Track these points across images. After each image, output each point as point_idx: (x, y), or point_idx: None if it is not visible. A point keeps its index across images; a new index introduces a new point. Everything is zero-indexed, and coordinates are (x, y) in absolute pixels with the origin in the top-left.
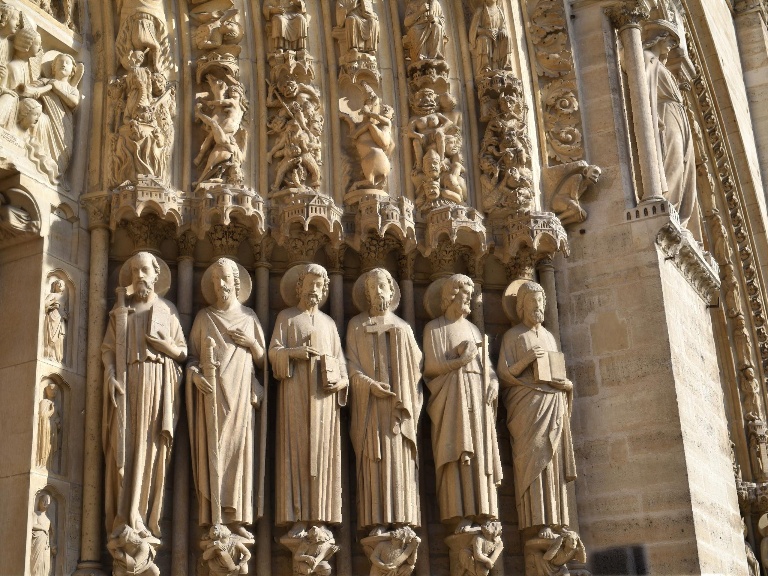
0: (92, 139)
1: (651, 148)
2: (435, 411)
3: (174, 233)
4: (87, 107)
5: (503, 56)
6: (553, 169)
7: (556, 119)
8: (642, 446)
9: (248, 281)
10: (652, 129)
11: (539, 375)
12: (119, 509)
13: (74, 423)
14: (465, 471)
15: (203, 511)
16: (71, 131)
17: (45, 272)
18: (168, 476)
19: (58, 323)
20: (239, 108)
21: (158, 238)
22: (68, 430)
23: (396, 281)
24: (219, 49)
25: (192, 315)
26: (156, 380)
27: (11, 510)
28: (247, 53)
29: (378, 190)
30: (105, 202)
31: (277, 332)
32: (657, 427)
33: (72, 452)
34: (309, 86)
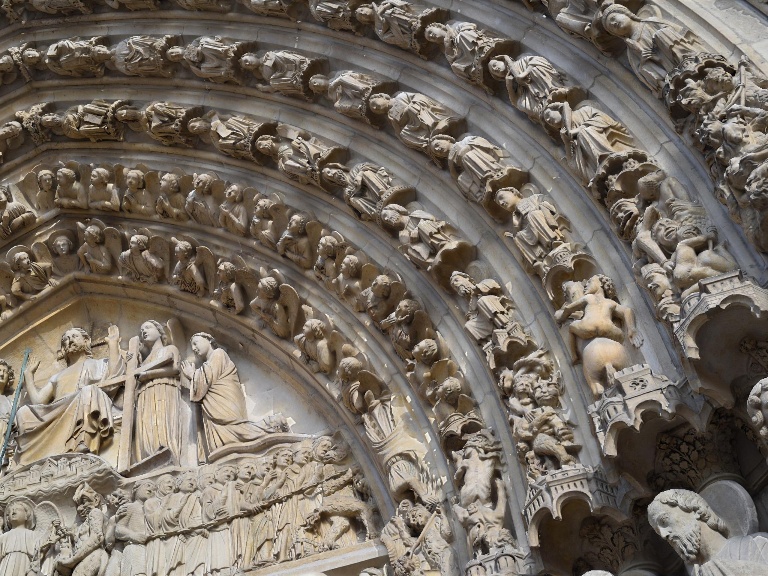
0: None
1: None
2: None
3: None
4: None
5: (671, 58)
6: None
7: None
8: None
9: None
10: None
11: None
12: None
13: None
14: None
15: None
16: None
17: None
18: None
19: None
20: (477, 462)
21: None
22: None
23: (767, 472)
24: None
25: None
26: None
27: None
28: (482, 391)
29: None
30: None
31: None
32: None
33: None
34: None
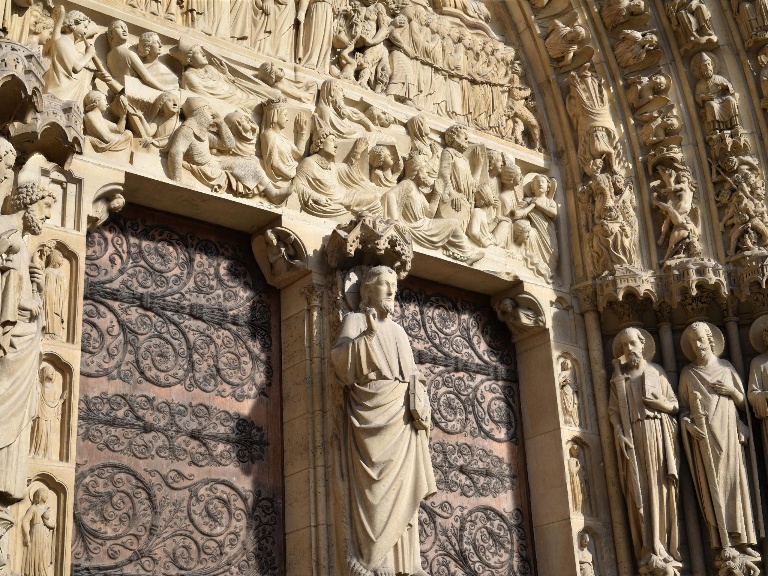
0: (572, 239)
1: None
2: None
3: (651, 305)
4: (564, 213)
5: None
6: None
7: None
8: None
9: (720, 337)
10: None
11: None
12: (644, 541)
13: (597, 474)
14: None
15: (713, 537)
16: (555, 237)
17: (555, 356)
18: (679, 509)
19: (571, 395)
20: (689, 190)
21: (639, 312)
22: (593, 480)
23: None
24: (663, 141)
25: (677, 372)
26: (657, 433)
27: (561, 549)
28: (688, 139)
29: None
30: (591, 290)
31: (753, 378)
32: None
33: (599, 497)
34: (747, 157)
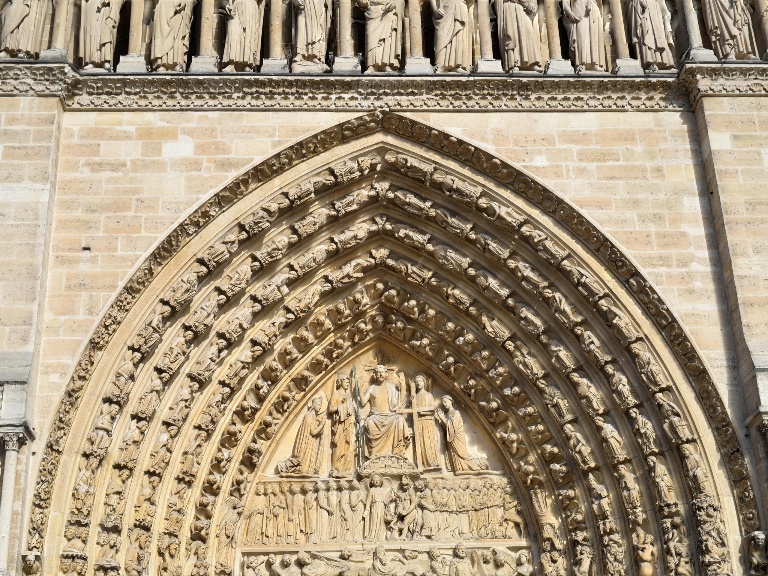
0: None
1: None
2: None
3: None
4: (539, 571)
5: None
6: (745, 538)
7: (744, 506)
8: None
9: None
10: None
11: None
12: None
13: None
14: None
15: None
16: None
17: None
18: None
19: None
20: (587, 558)
21: None
22: None
23: None
24: (578, 527)
25: None
26: None
27: None
28: (590, 524)
29: None
30: None
31: None
32: None
33: None
34: None
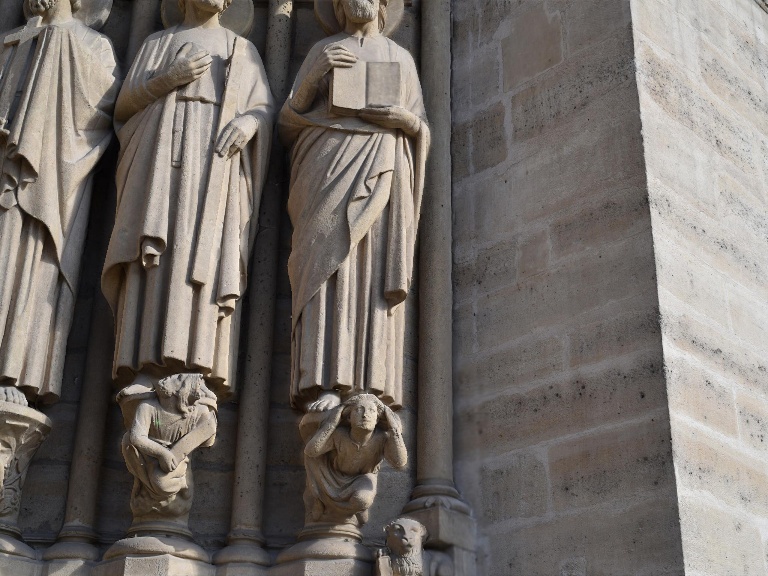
0: None
1: None
2: (119, 177)
3: None
4: None
5: None
6: None
7: None
8: (574, 237)
9: None
10: None
11: (333, 97)
12: None
13: None
14: (148, 278)
15: None
16: None
17: None
18: None
19: None
20: None
21: None
22: None
23: None
24: None
25: None
26: None
27: None
28: None
29: None
30: None
31: None
32: (602, 194)
33: None
34: None
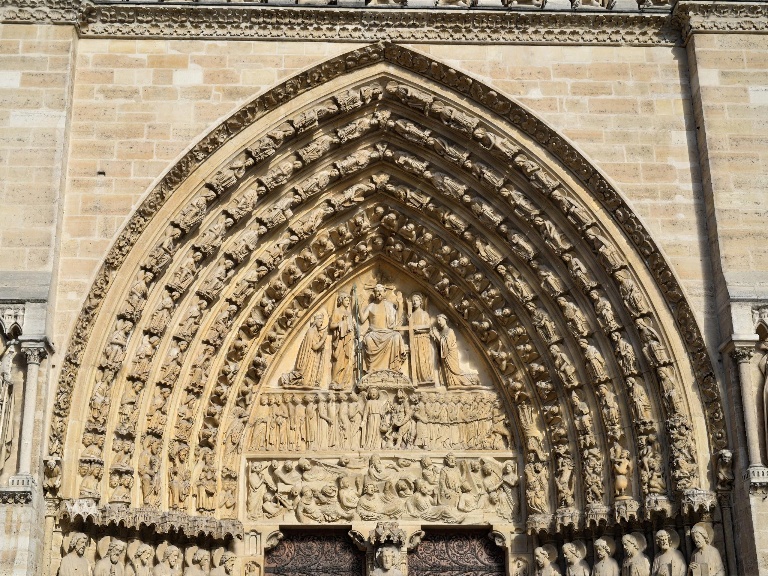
0: None
1: (750, 436)
2: None
3: None
4: (524, 480)
5: (673, 406)
6: None
7: (714, 426)
8: None
9: (584, 548)
10: (752, 424)
11: None
12: None
13: None
14: None
15: None
16: (516, 496)
17: (511, 562)
18: None
19: None
20: (567, 470)
21: None
22: None
23: None
24: (561, 440)
25: None
26: None
27: None
28: (572, 438)
29: (621, 497)
30: None
31: None
32: None
33: None
34: (594, 449)
